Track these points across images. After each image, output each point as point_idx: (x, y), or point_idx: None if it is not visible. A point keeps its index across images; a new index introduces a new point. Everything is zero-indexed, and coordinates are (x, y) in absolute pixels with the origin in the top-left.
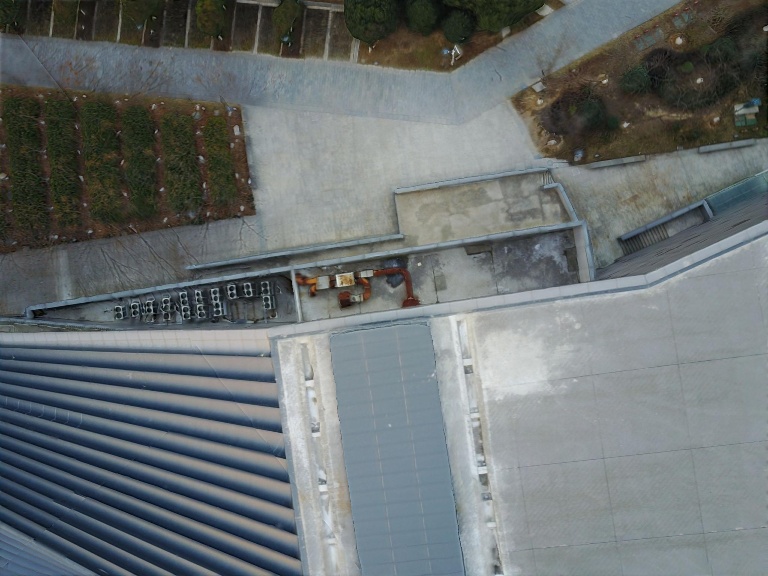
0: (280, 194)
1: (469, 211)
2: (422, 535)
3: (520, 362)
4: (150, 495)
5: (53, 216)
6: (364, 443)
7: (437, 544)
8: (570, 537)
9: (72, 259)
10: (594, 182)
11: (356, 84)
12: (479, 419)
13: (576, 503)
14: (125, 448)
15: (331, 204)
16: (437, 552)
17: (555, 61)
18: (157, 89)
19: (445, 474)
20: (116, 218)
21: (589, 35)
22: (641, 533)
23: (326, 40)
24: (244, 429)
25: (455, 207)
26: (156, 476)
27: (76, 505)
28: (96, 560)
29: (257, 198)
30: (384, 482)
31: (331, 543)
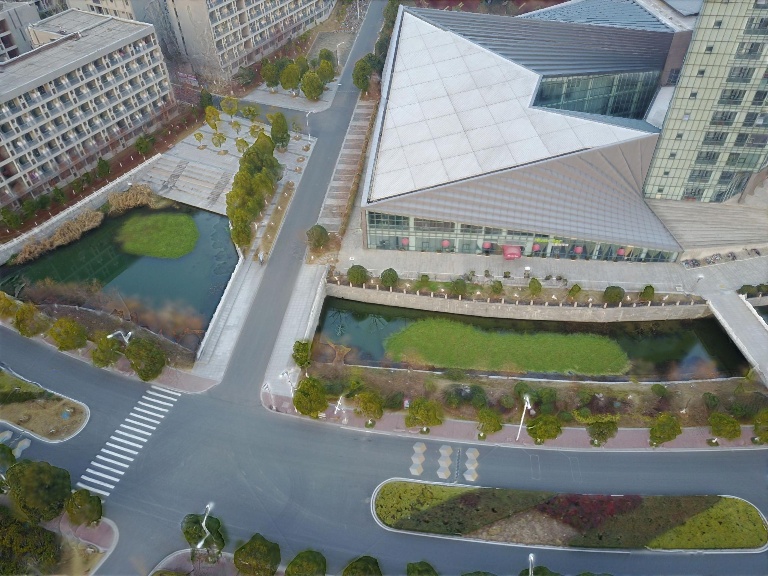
0: None
1: None
2: None
3: None
4: None
5: None
6: None
7: None
8: None
9: None
10: None
11: None
12: None
13: None
14: None
15: None
16: None
17: None
18: None
19: None
20: None
21: None
22: None
23: None
24: (616, 3)
25: None
26: None
27: None
28: None
29: None
30: None
31: (660, 11)
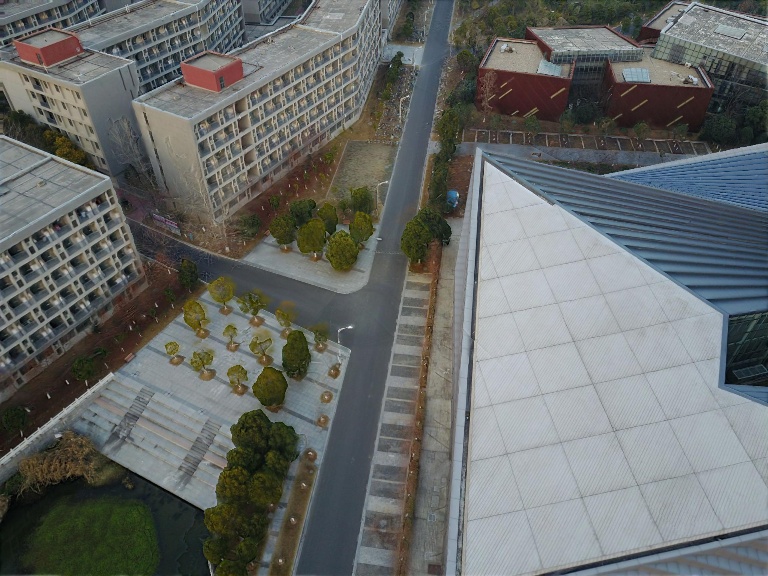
0: None
1: None
2: None
3: None
4: None
5: None
6: None
7: None
8: None
9: None
10: None
11: None
12: None
13: None
14: None
15: None
16: None
17: None
18: (611, 161)
19: None
20: None
21: None
22: None
23: (693, 150)
24: None
25: None
26: None
27: None
28: None
29: None
30: None
31: None
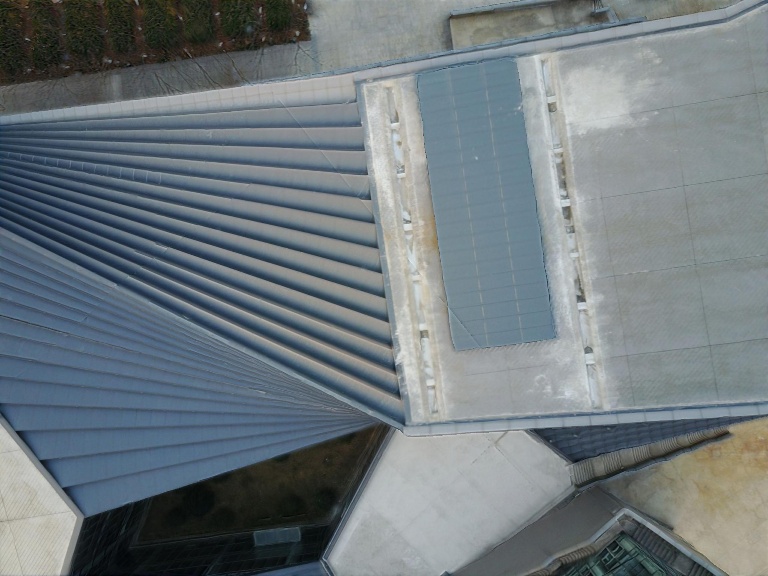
0: (335, 20)
1: (522, 36)
2: (508, 262)
3: (603, 97)
4: (232, 245)
5: (107, 39)
6: (451, 176)
7: (523, 270)
8: (651, 263)
9: (126, 84)
10: (642, 11)
11: None
12: (562, 155)
13: (657, 230)
14: (206, 202)
15: (386, 30)
16: (522, 278)
17: None
18: None
19: (531, 203)
20: (171, 42)
21: None
22: (719, 256)
23: None
24: (328, 175)
25: (509, 32)
26: (238, 227)
27: (158, 255)
28: (179, 305)
29: (312, 24)
30: (471, 213)
31: (415, 280)
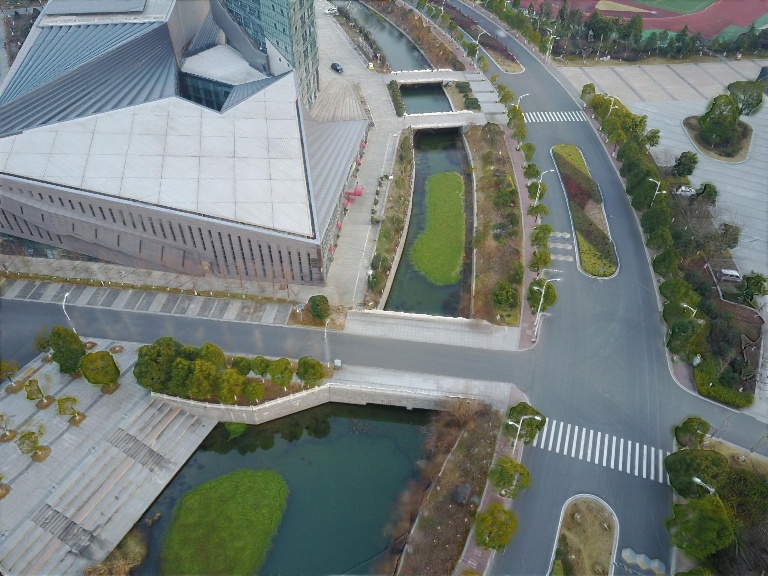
0: None
1: None
2: None
3: None
4: None
5: None
6: (83, 9)
7: None
8: None
9: None
10: None
11: None
12: None
13: None
14: None
15: None
16: (125, 0)
17: (4, 65)
18: None
19: None
20: None
21: (1, 59)
22: None
23: None
24: None
25: None
26: None
27: None
28: None
29: None
30: None
31: (115, 19)
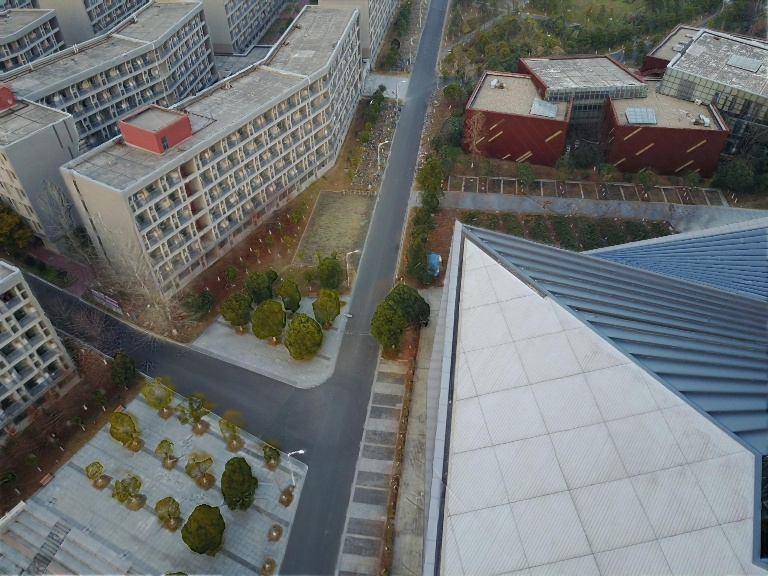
0: None
1: None
2: None
3: None
4: None
5: None
6: None
7: None
8: None
9: None
10: None
11: (734, 214)
12: None
13: None
14: (762, 265)
15: None
16: None
17: None
18: (614, 214)
19: None
20: None
21: None
22: None
23: (706, 199)
24: None
25: None
26: None
27: None
28: None
29: None
30: None
31: None
